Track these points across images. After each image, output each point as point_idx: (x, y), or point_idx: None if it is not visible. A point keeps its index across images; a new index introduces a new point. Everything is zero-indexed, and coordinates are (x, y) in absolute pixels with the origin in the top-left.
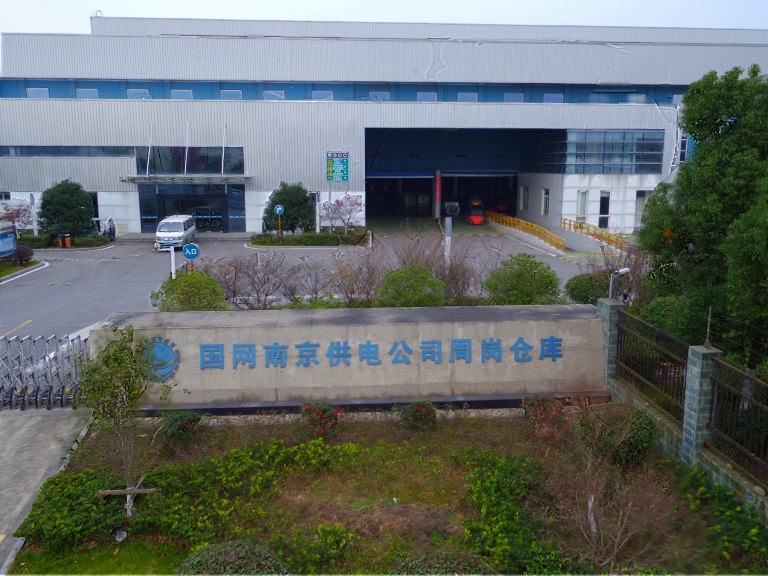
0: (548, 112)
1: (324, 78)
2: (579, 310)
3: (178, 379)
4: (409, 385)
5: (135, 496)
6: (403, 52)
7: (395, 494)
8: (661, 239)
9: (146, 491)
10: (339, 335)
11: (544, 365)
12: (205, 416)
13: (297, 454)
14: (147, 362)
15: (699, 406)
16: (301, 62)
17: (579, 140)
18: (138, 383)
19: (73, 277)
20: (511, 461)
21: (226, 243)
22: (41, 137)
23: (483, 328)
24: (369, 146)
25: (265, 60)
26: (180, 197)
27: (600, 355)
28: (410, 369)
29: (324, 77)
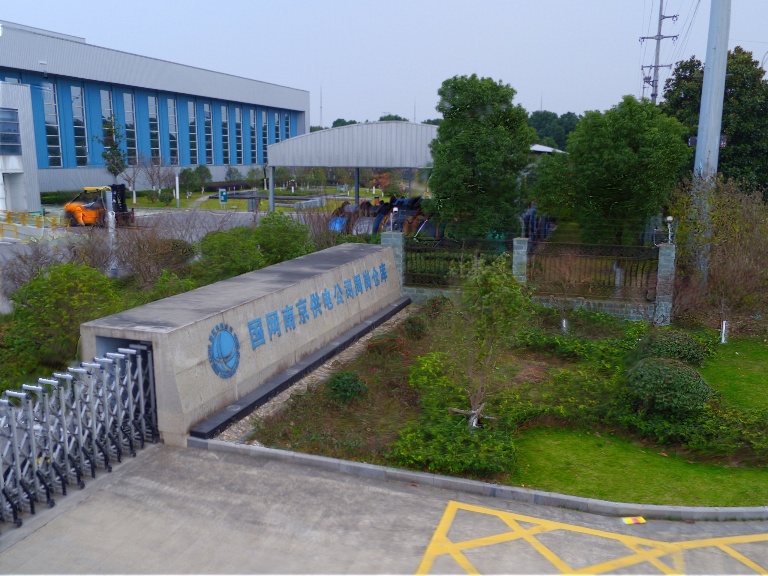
0: None
1: None
2: None
3: (242, 367)
4: None
5: None
6: None
7: None
8: None
9: None
10: (312, 287)
11: (383, 285)
12: (278, 395)
13: None
14: (219, 357)
15: None
16: None
17: None
18: None
19: None
20: None
21: None
22: None
23: (361, 264)
24: None
25: None
26: None
27: (396, 272)
28: (344, 307)
29: None
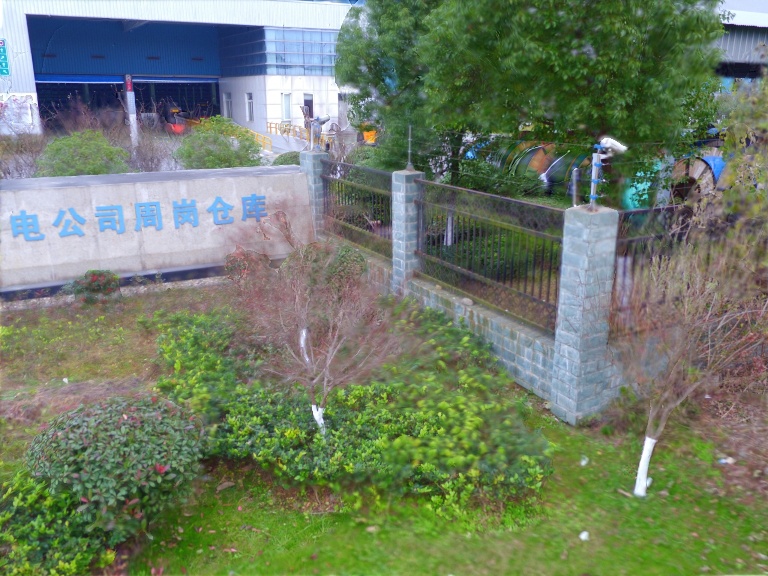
0: (243, 7)
1: None
2: (282, 169)
3: None
4: (86, 262)
5: None
6: None
7: (65, 374)
8: (357, 67)
9: None
10: None
11: (248, 227)
12: None
13: None
14: None
15: (406, 233)
16: None
17: (277, 39)
18: None
19: None
20: (212, 316)
21: None
22: None
23: (173, 188)
24: (34, 37)
25: None
26: None
27: (307, 212)
28: (85, 242)
29: None
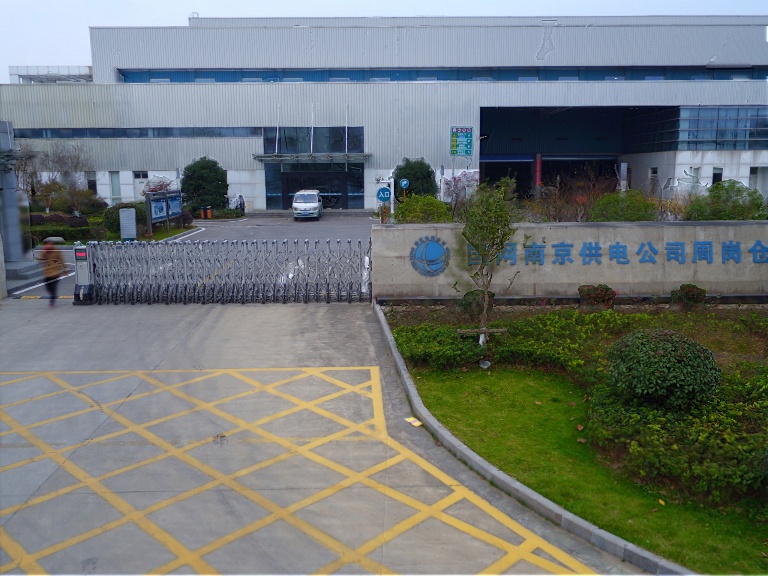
0: (661, 89)
1: (430, 64)
2: None
3: (448, 274)
4: (655, 283)
5: (488, 335)
6: (507, 37)
7: None
8: None
9: (499, 330)
10: (591, 236)
11: None
12: None
13: (597, 319)
14: (421, 258)
15: None
16: (408, 49)
17: (692, 117)
18: (509, 229)
19: (239, 235)
20: None
21: (351, 217)
22: (177, 119)
23: (723, 231)
24: (483, 125)
25: (374, 48)
26: (303, 175)
27: None
28: (656, 268)
29: (430, 63)
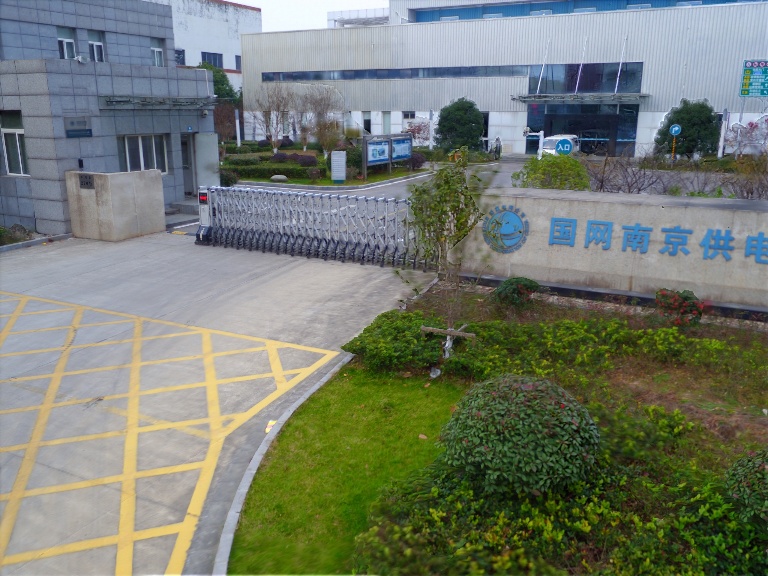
0: None
1: None
2: None
3: (524, 252)
4: None
5: (454, 338)
6: None
7: (767, 405)
8: None
9: (465, 335)
10: (721, 222)
11: None
12: (546, 294)
13: (641, 338)
14: None
15: None
16: None
17: None
18: (467, 212)
19: None
20: None
21: None
22: (446, 59)
23: None
24: None
25: None
26: (568, 118)
27: None
28: None
29: None
